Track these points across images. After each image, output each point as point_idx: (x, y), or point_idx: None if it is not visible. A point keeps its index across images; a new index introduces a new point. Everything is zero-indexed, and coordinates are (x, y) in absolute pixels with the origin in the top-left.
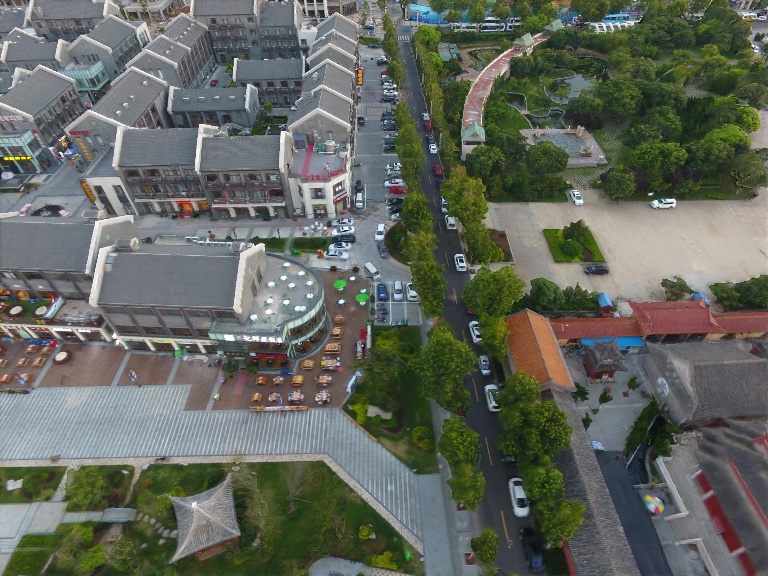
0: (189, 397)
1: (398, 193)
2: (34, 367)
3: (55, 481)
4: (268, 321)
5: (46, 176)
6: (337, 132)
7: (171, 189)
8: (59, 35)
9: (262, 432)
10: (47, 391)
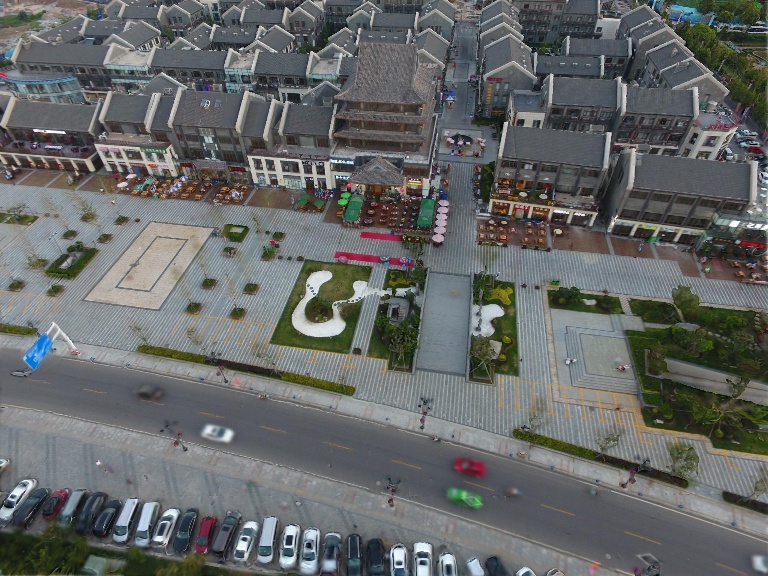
0: (681, 268)
1: (757, 152)
2: (541, 236)
3: (617, 304)
4: (762, 216)
5: (438, 114)
6: (714, 96)
7: (579, 128)
8: (389, 11)
9: (760, 296)
10: (563, 252)
